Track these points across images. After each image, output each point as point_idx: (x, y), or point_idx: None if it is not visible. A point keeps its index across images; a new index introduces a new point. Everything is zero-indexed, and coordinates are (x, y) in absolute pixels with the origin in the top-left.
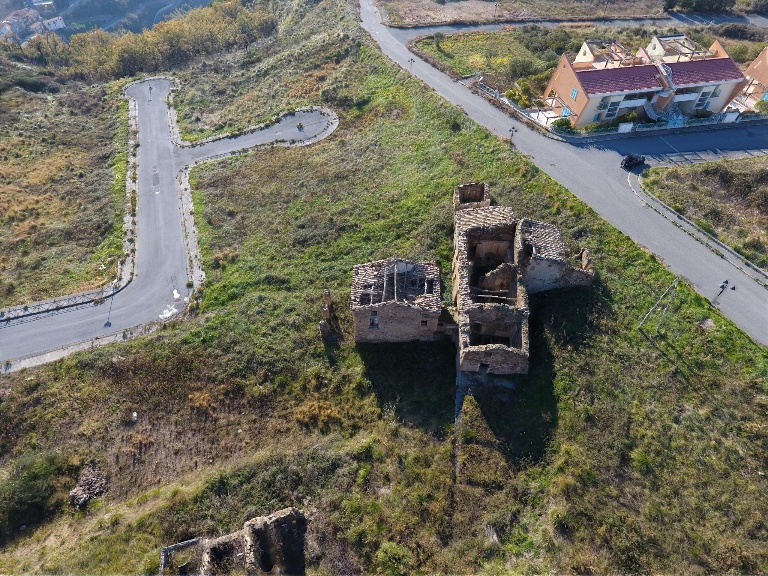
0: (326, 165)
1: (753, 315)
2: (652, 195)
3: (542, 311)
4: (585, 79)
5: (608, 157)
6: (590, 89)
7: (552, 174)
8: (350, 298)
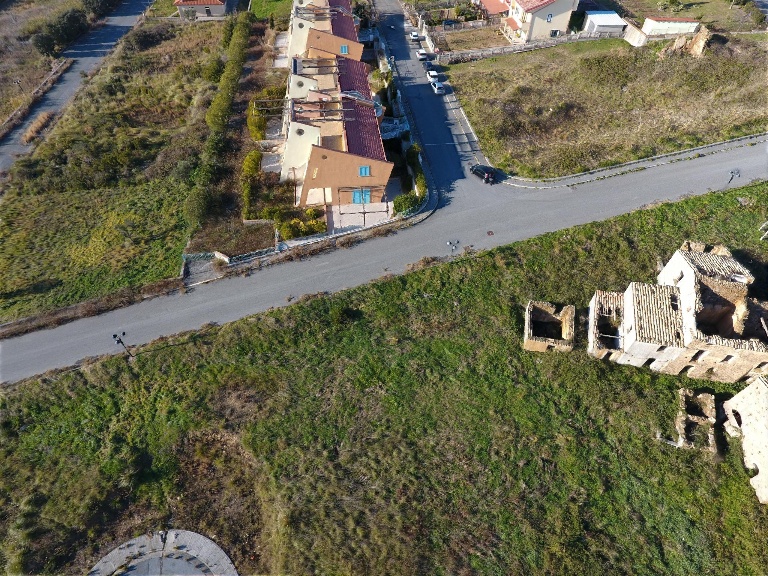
0: (368, 560)
1: (717, 177)
2: (556, 178)
3: (763, 299)
4: (360, 151)
5: (470, 188)
6: (377, 155)
7: (513, 238)
8: (759, 514)
